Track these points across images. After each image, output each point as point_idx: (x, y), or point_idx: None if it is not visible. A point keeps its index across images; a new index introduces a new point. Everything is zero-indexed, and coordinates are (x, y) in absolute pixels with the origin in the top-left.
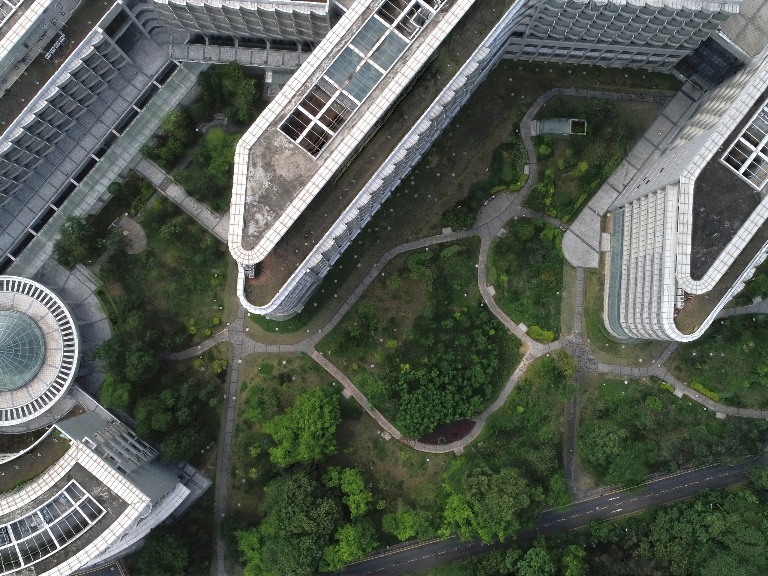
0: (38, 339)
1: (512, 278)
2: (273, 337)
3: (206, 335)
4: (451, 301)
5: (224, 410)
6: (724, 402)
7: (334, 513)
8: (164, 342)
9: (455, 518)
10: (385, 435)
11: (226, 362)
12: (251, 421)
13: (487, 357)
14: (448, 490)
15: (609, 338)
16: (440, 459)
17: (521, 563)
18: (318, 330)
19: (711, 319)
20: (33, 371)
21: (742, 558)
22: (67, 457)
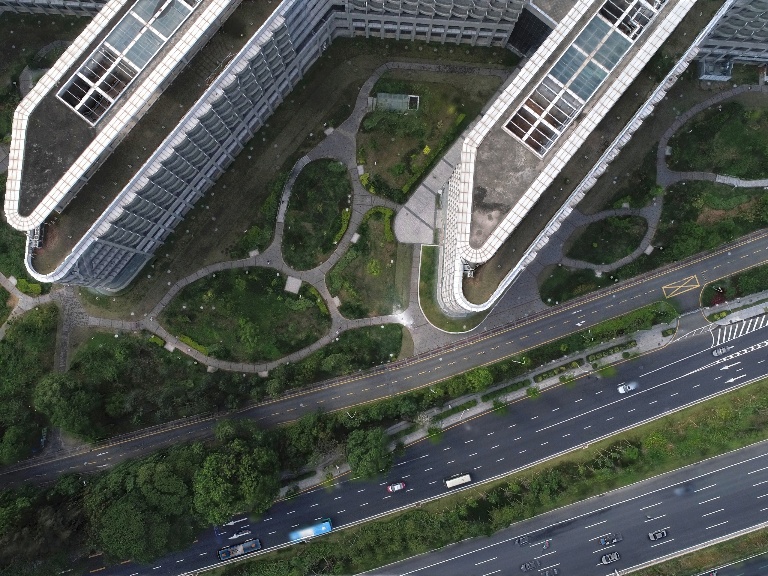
0: None
1: (1, 231)
2: None
3: None
4: None
5: None
6: (215, 356)
7: None
8: None
9: None
10: None
11: None
12: None
13: None
14: None
15: (100, 291)
16: None
17: None
18: None
19: (72, 259)
20: None
21: (151, 507)
22: None
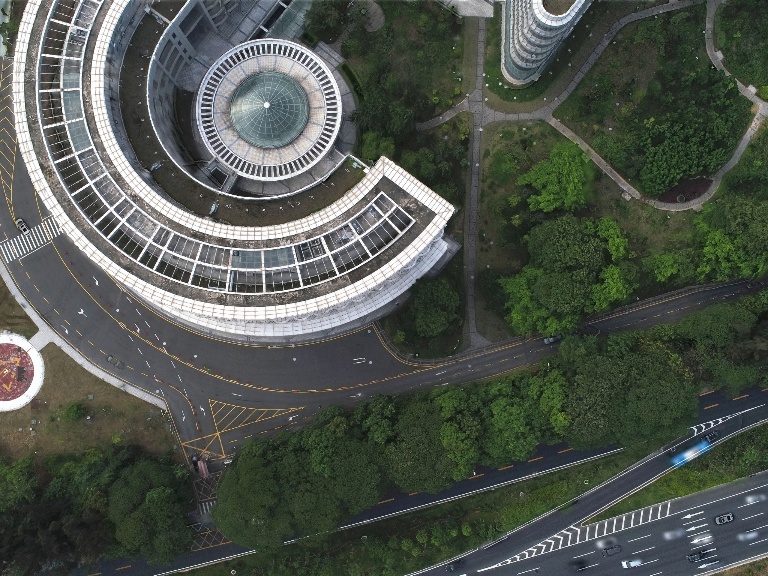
0: (302, 98)
1: (740, 41)
2: (511, 106)
3: (448, 105)
4: (683, 65)
5: (468, 176)
6: None
7: (600, 251)
8: (418, 103)
9: (717, 252)
10: (625, 195)
11: (469, 130)
12: (496, 185)
13: (724, 113)
14: (705, 229)
15: None
16: (680, 216)
17: None
18: (554, 98)
19: None
20: (299, 128)
21: None
22: (374, 171)
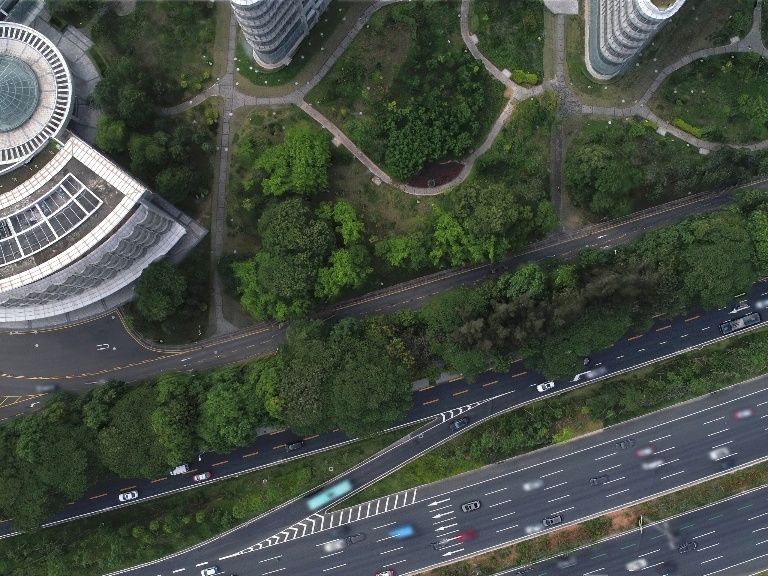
0: (32, 81)
1: (494, 25)
2: (262, 90)
3: (197, 89)
4: (435, 48)
5: (217, 161)
6: (707, 138)
7: (327, 234)
8: (156, 86)
9: (446, 236)
10: (376, 180)
11: (217, 114)
12: (244, 170)
13: (472, 97)
14: (438, 213)
15: (591, 80)
16: (430, 201)
17: (512, 278)
18: (306, 82)
19: None
20: (28, 112)
21: (727, 250)
22: (63, 152)
